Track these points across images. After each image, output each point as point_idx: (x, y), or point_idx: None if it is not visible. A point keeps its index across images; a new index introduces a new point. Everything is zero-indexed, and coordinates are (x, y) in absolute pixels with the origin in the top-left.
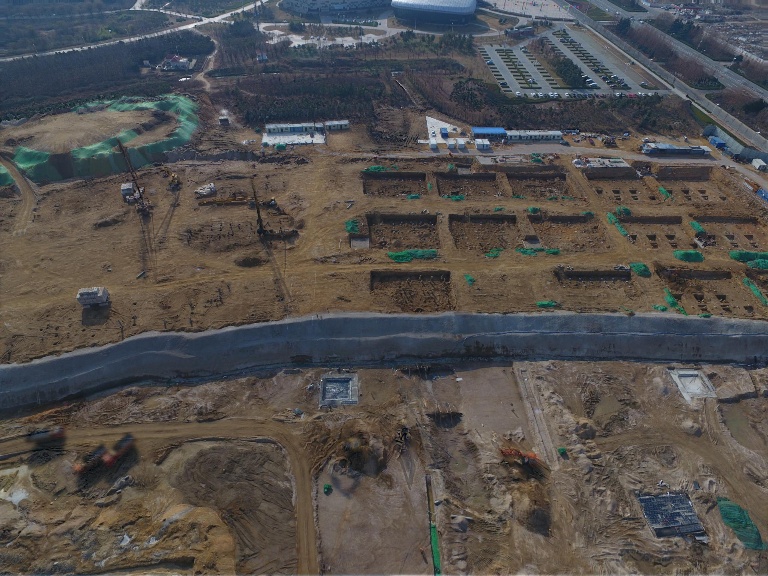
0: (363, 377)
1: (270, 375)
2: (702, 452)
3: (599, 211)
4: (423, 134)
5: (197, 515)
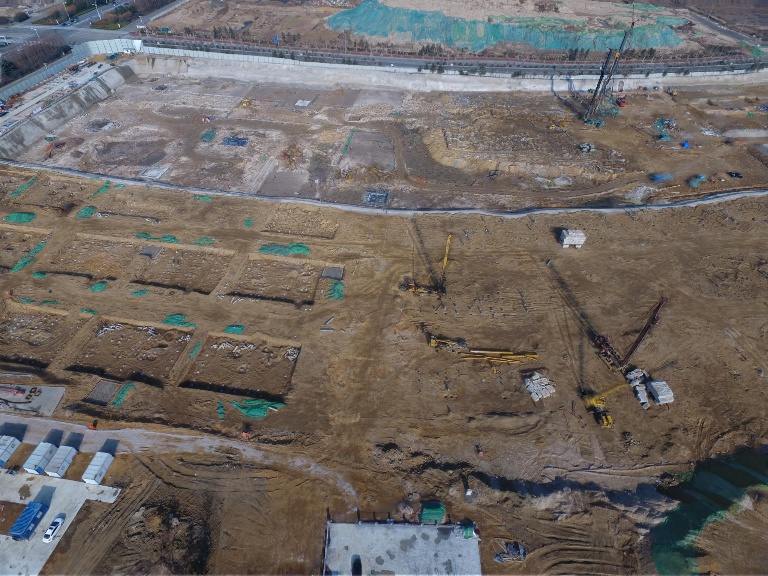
0: (359, 201)
1: (421, 209)
2: (192, 152)
3: (20, 276)
4: (78, 536)
5: (449, 160)
